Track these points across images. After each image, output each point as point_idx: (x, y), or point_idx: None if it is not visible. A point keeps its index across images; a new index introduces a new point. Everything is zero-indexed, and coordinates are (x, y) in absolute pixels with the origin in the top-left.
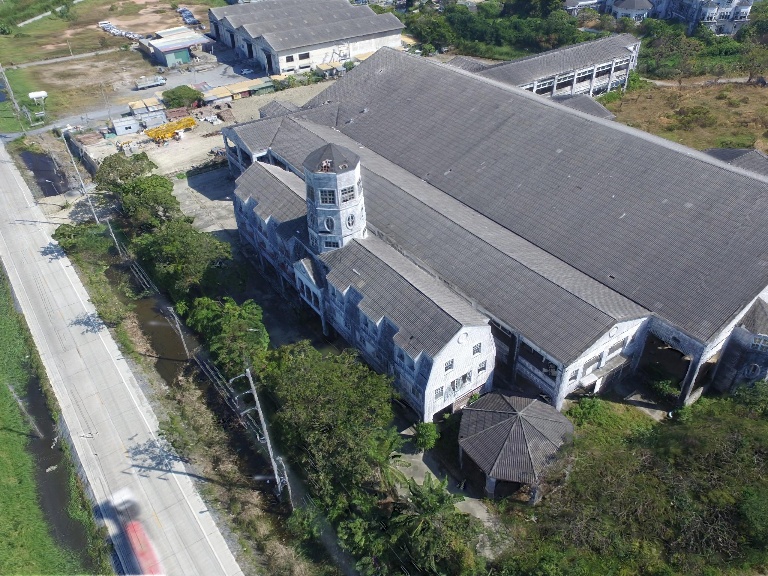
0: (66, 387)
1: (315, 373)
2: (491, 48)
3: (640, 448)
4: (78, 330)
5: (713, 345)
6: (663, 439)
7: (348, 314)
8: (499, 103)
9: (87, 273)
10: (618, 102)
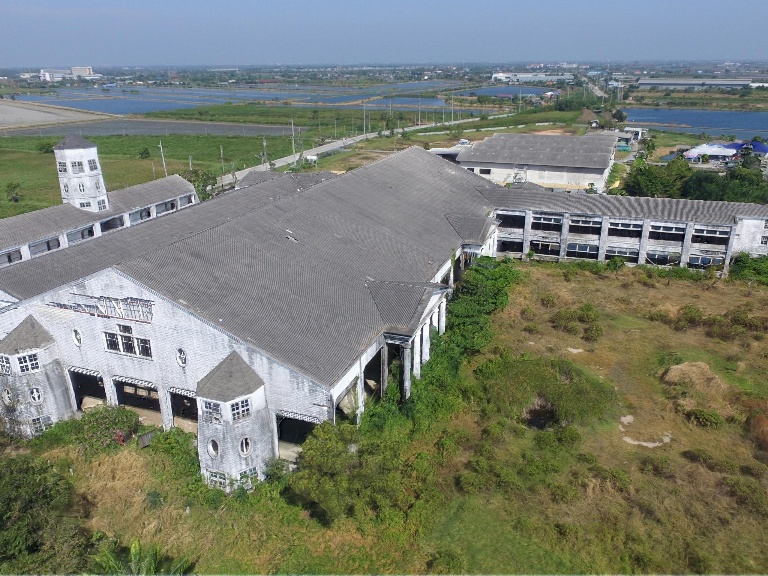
0: None
1: None
2: None
3: None
4: None
5: None
6: None
7: None
8: None
9: None
10: (680, 281)
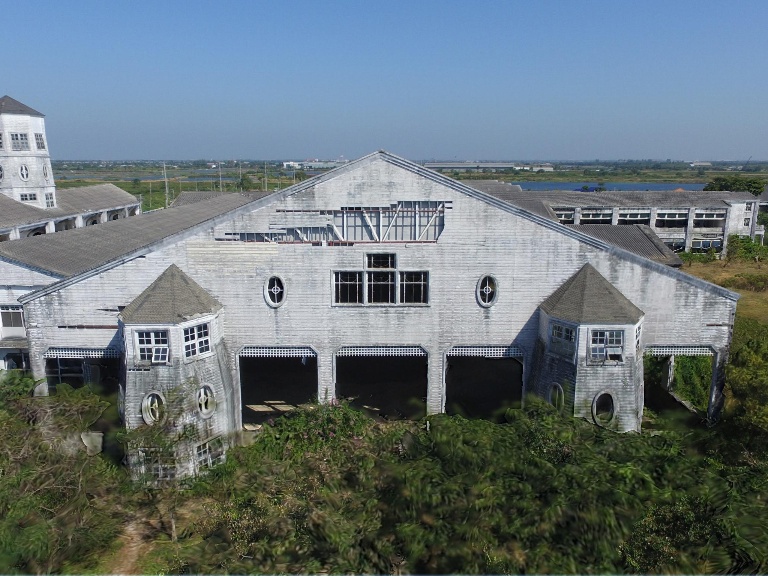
0: None
1: None
2: None
3: None
4: None
5: (59, 318)
6: None
7: None
8: None
9: None
10: (694, 263)
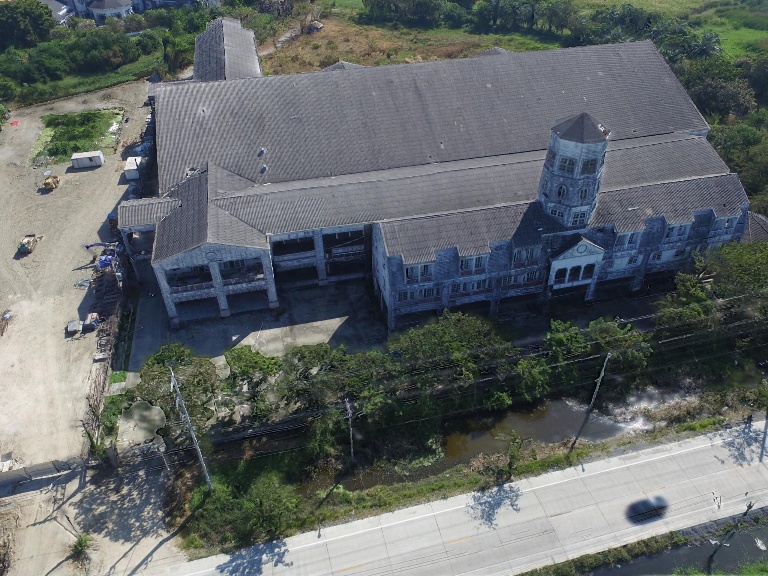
0: (630, 528)
1: (759, 260)
2: (56, 85)
3: (751, 194)
4: (508, 516)
5: None
6: (754, 180)
7: (643, 246)
8: (388, 78)
9: (349, 511)
10: None
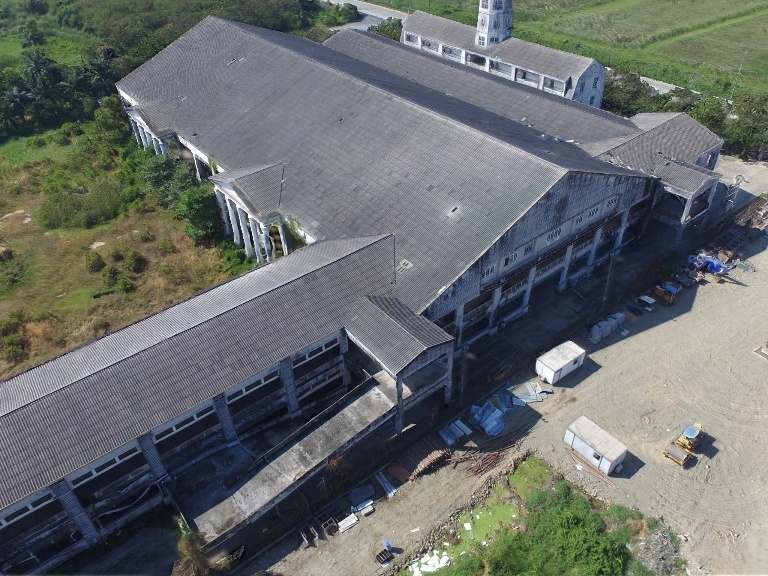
0: None
1: None
2: None
3: None
4: None
5: None
6: None
7: None
8: None
9: None
10: None
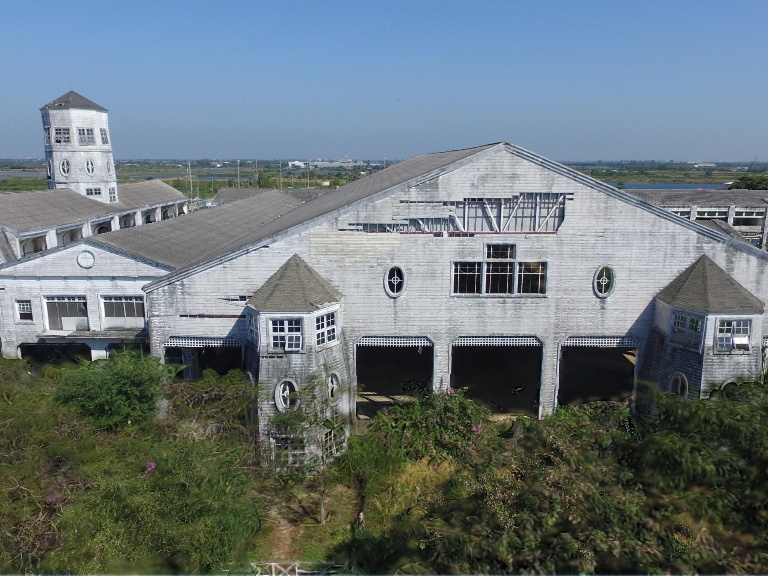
0: None
1: None
2: None
3: None
4: None
5: (181, 307)
6: None
7: None
8: None
9: None
10: None
